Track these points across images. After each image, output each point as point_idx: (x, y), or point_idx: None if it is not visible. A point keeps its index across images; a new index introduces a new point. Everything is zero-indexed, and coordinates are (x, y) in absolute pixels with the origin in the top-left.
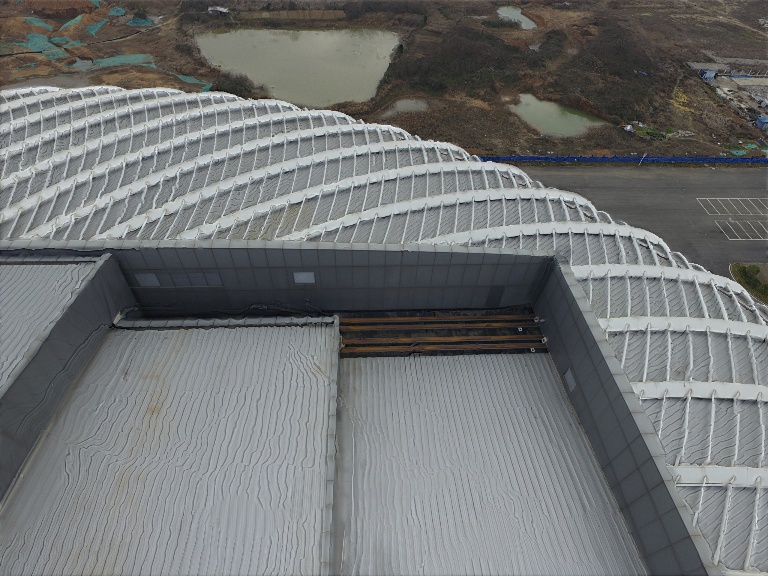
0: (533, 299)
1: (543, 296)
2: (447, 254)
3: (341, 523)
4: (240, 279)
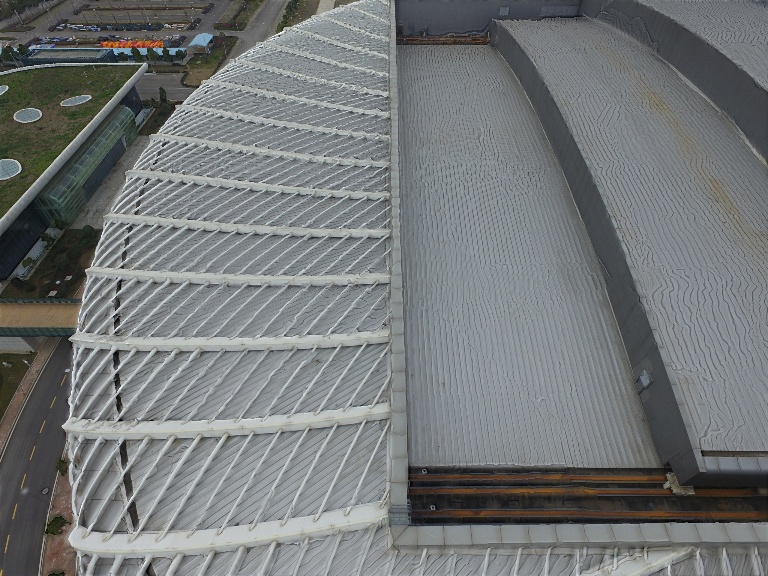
0: None
1: None
2: None
3: (615, 274)
4: None
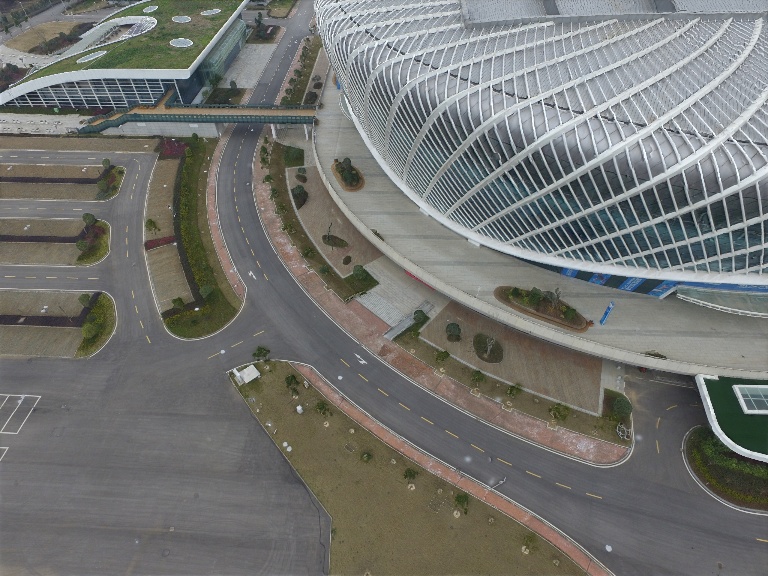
0: None
1: None
2: None
3: None
4: None
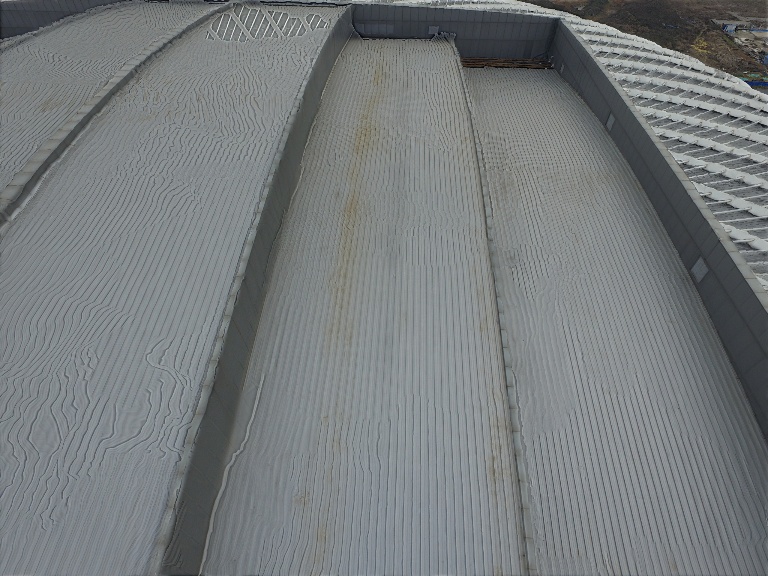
0: (548, 48)
1: (553, 43)
2: (505, 14)
3: None
4: (403, 29)
